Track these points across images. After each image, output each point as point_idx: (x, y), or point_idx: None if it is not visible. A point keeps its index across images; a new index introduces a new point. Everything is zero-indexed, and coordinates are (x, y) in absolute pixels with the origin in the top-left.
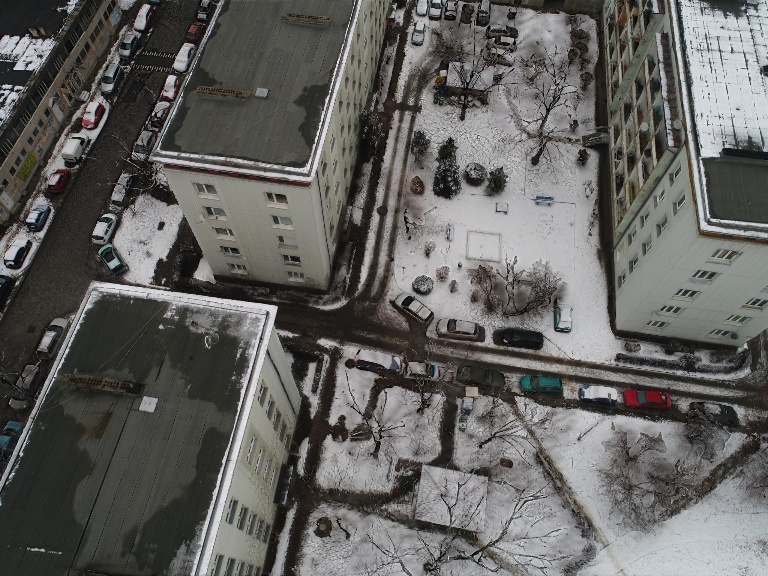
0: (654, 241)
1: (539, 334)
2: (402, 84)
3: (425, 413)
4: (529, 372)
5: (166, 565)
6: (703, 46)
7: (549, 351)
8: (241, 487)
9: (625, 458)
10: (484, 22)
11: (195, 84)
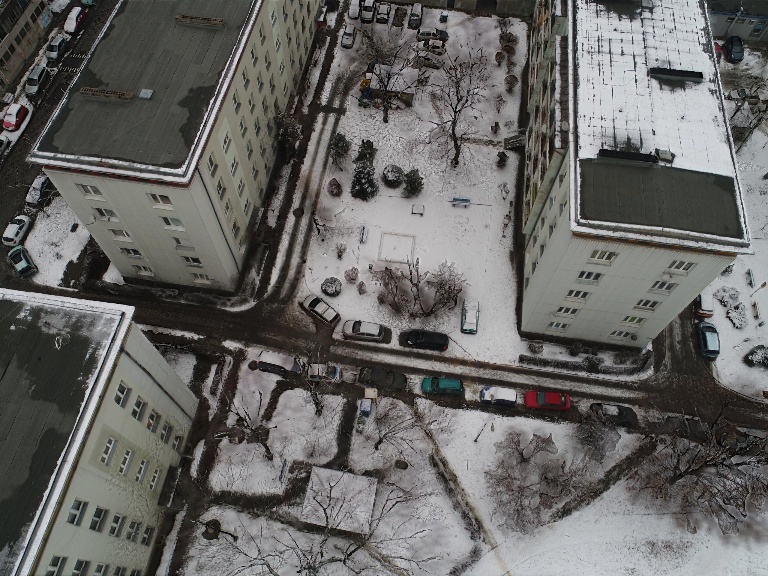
0: (547, 242)
1: (443, 336)
2: (329, 87)
3: (324, 415)
4: (432, 374)
5: None
6: (594, 48)
7: (454, 353)
8: (93, 488)
9: (519, 459)
10: (415, 25)
11: (81, 85)
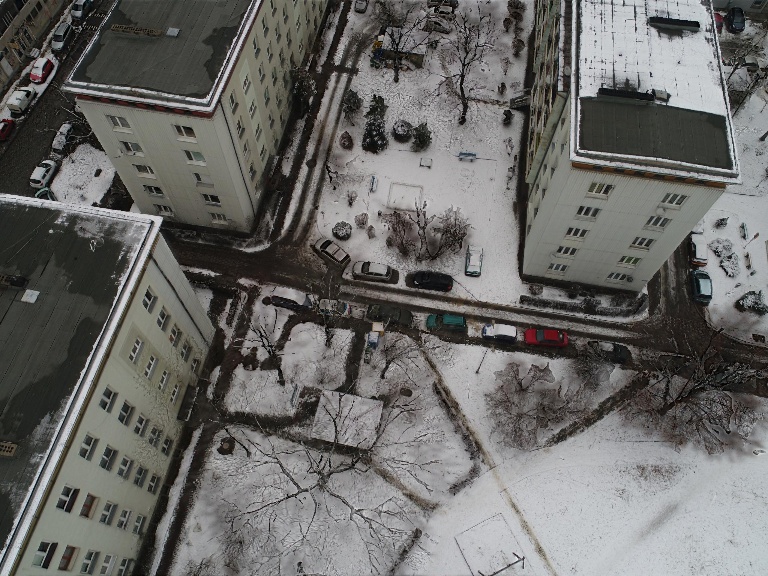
0: (549, 184)
1: (448, 276)
2: (342, 48)
3: (333, 346)
4: (437, 312)
5: (30, 431)
6: None
7: (458, 293)
8: (122, 381)
9: (517, 389)
10: None
11: (112, 24)
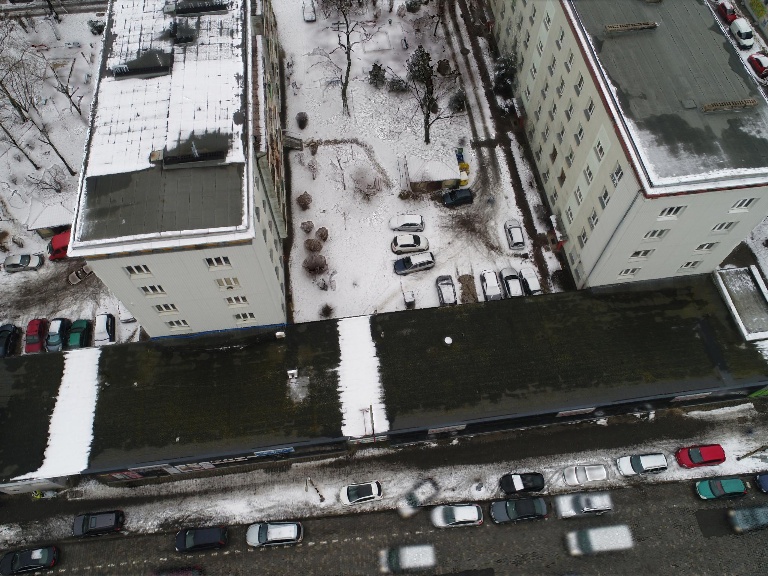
0: None
1: None
2: (503, 168)
3: None
4: None
5: None
6: None
7: None
8: None
9: None
10: None
11: None
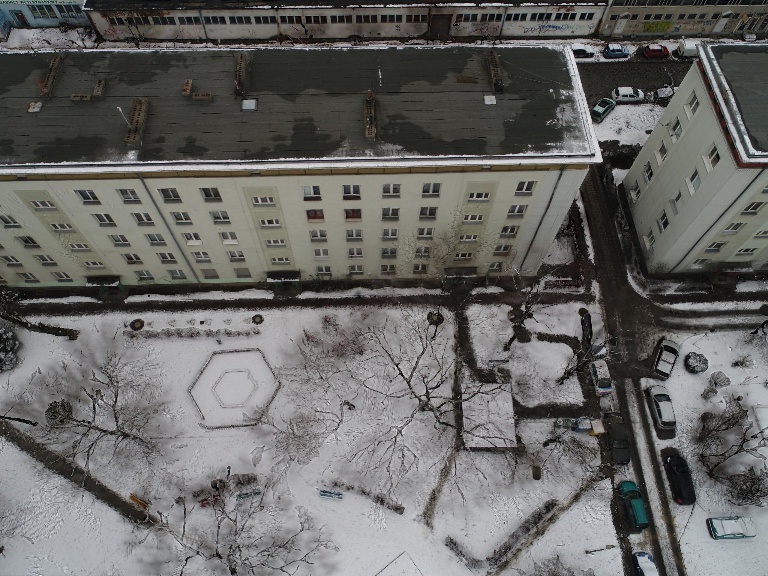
0: None
1: (693, 495)
2: None
3: (560, 386)
4: (643, 492)
5: (387, 141)
6: None
7: (678, 514)
8: (450, 196)
9: None
10: None
11: None
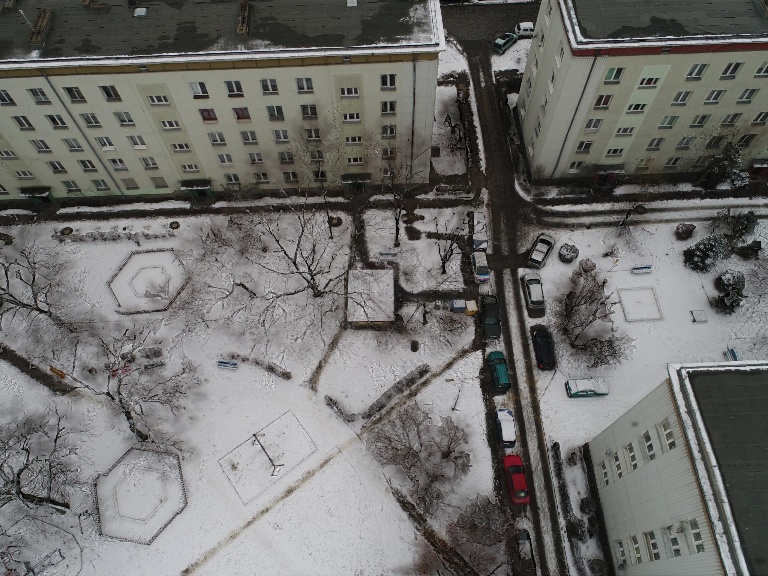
0: None
1: (552, 360)
2: None
3: (443, 275)
4: (511, 362)
5: (258, 38)
6: None
7: (540, 379)
8: (323, 92)
9: (443, 448)
10: None
11: None
